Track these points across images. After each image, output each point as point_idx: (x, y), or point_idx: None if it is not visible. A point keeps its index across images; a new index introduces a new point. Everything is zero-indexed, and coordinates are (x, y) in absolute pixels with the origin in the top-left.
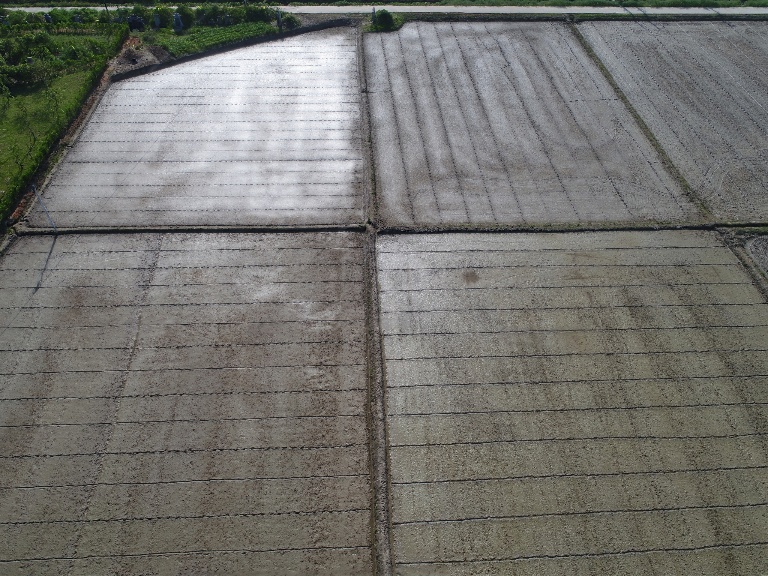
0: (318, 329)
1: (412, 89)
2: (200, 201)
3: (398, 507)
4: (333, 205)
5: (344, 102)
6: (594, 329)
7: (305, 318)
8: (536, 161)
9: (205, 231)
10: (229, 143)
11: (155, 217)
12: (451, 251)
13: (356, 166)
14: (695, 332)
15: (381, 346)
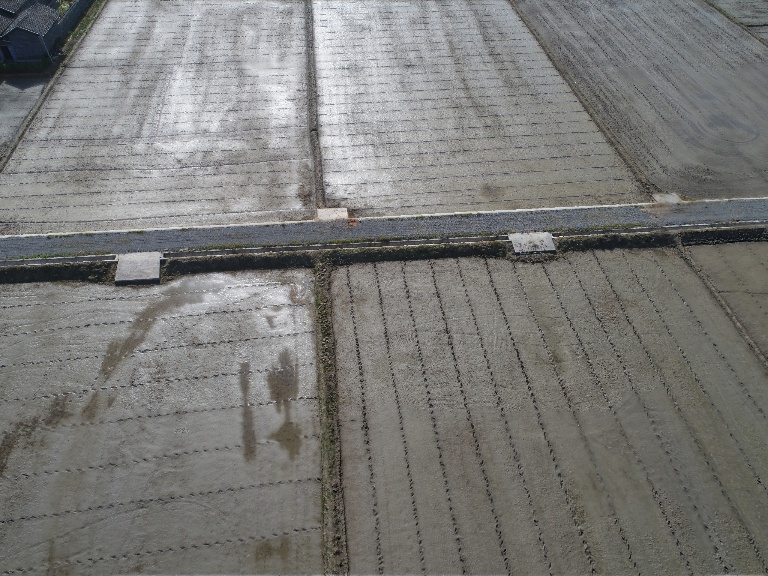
0: (281, 9)
1: None
2: None
3: (317, 44)
4: None
5: None
6: (416, 6)
7: (275, 7)
8: None
9: None
10: None
11: None
12: None
13: None
14: (465, 6)
15: (312, 11)
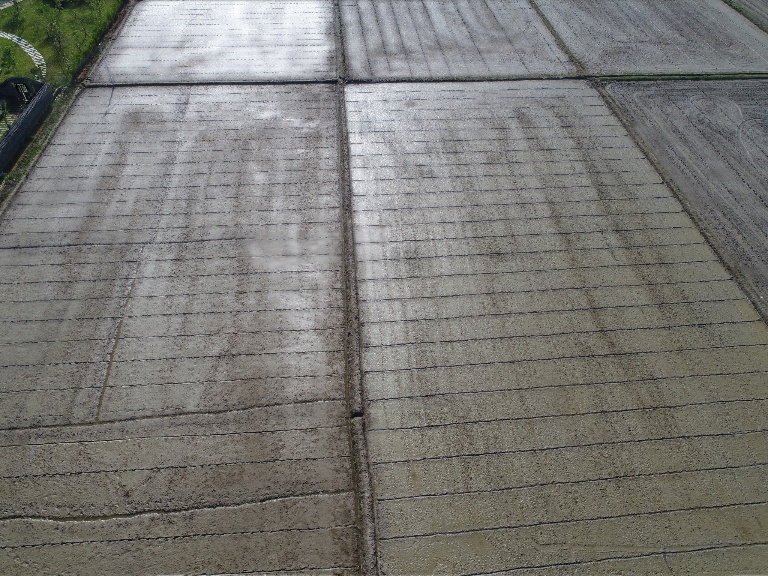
0: (304, 131)
1: (374, 3)
2: (216, 68)
3: (357, 205)
4: (313, 70)
5: (321, 12)
6: (492, 128)
7: (295, 126)
8: (464, 44)
9: (221, 84)
10: (234, 36)
11: (184, 77)
12: (398, 92)
13: (330, 48)
14: (560, 129)
15: (347, 137)
